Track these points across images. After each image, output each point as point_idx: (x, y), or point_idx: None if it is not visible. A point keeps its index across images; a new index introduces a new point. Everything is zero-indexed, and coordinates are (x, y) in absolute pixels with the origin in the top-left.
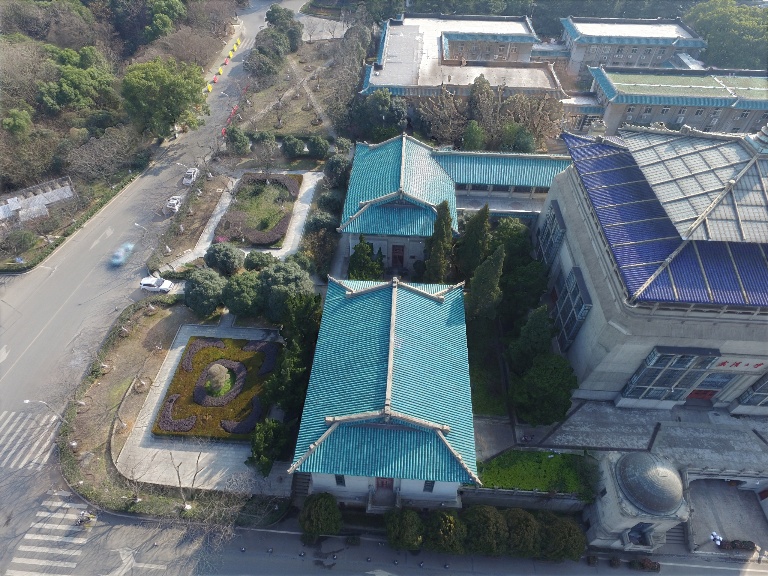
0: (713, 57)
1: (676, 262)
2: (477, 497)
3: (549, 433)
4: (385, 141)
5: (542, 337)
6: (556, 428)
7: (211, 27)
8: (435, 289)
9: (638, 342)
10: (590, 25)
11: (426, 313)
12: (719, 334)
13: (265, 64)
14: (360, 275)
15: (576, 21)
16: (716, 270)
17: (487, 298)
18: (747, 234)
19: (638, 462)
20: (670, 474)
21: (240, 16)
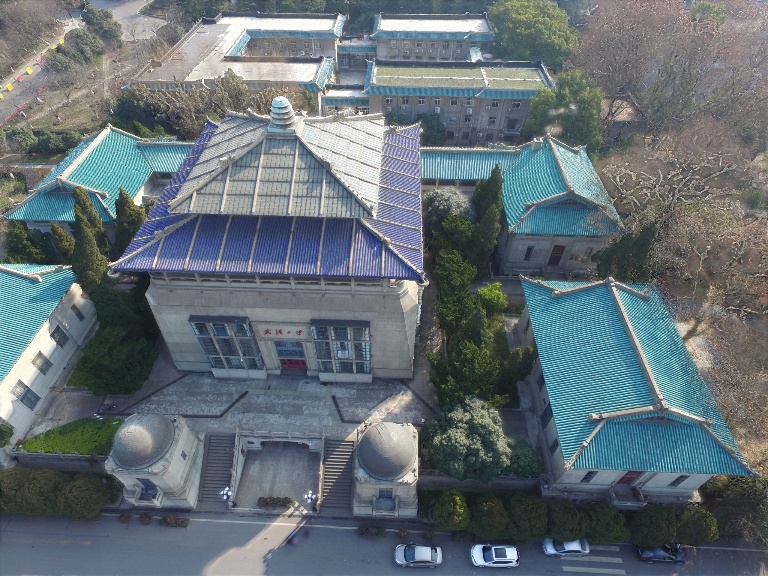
0: (498, 50)
1: (174, 235)
2: (37, 462)
3: (136, 402)
4: (95, 133)
5: (107, 310)
6: (145, 398)
7: (20, 28)
8: (47, 269)
9: (171, 312)
10: (399, 21)
11: (7, 290)
12: (237, 302)
13: (61, 63)
14: (16, 259)
15: (388, 17)
16: (206, 241)
17: (84, 276)
18: (227, 207)
19: (125, 421)
20: (139, 430)
21: (79, 17)
